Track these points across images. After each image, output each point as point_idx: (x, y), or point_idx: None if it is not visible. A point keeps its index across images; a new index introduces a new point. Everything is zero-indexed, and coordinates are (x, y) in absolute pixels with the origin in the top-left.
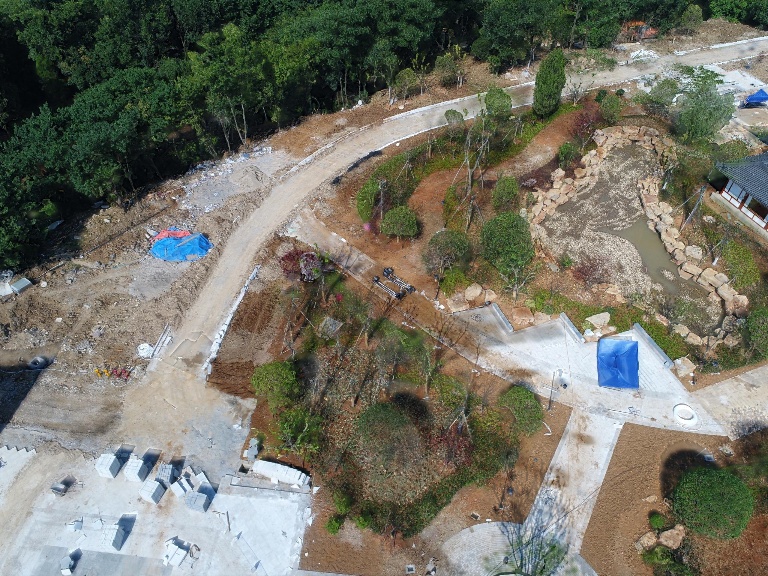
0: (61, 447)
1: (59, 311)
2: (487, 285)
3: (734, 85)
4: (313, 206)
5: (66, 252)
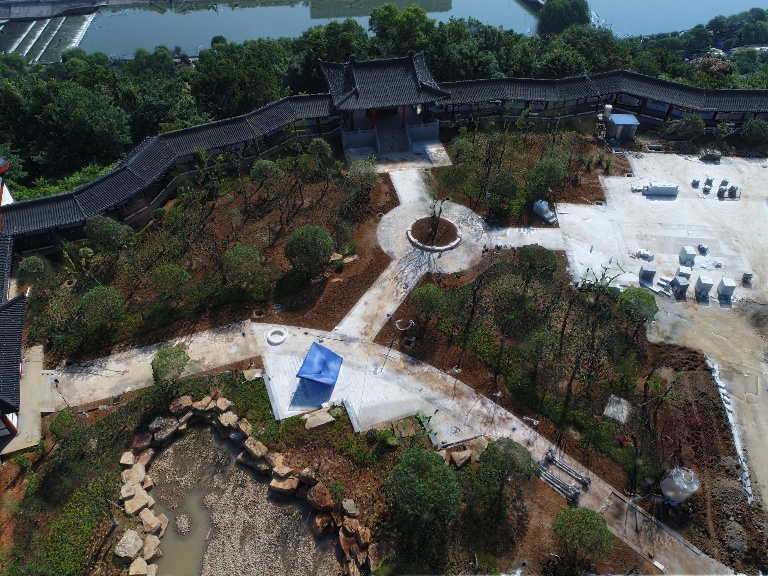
0: None
1: None
2: None
3: None
4: None
5: None
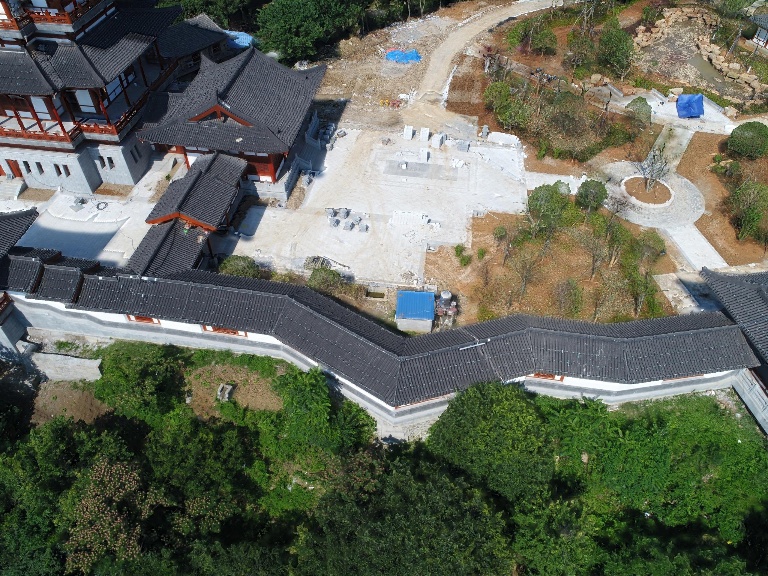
0: (375, 129)
1: (342, 81)
2: (603, 76)
3: None
4: (479, 42)
5: (332, 57)
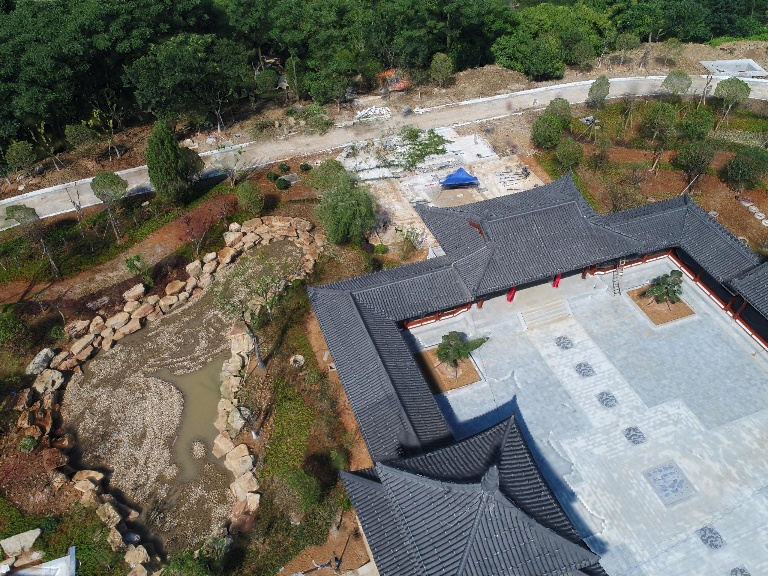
0: None
1: None
2: None
3: (457, 155)
4: None
5: None
